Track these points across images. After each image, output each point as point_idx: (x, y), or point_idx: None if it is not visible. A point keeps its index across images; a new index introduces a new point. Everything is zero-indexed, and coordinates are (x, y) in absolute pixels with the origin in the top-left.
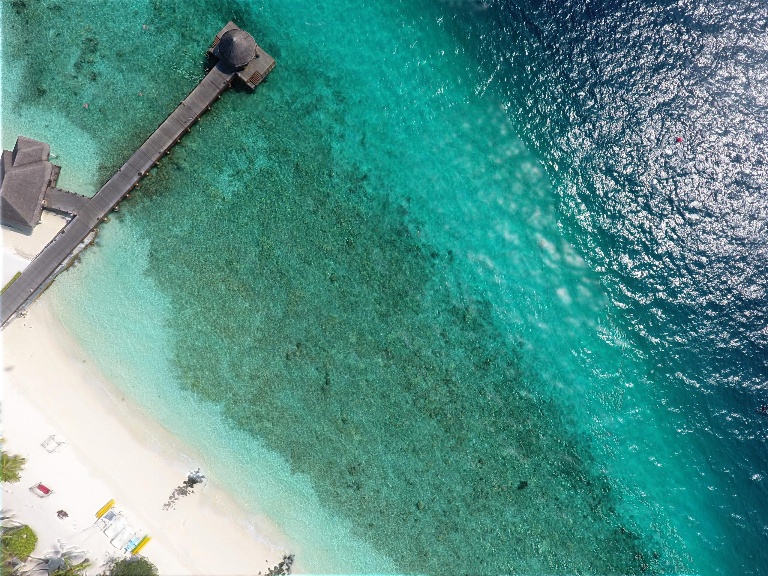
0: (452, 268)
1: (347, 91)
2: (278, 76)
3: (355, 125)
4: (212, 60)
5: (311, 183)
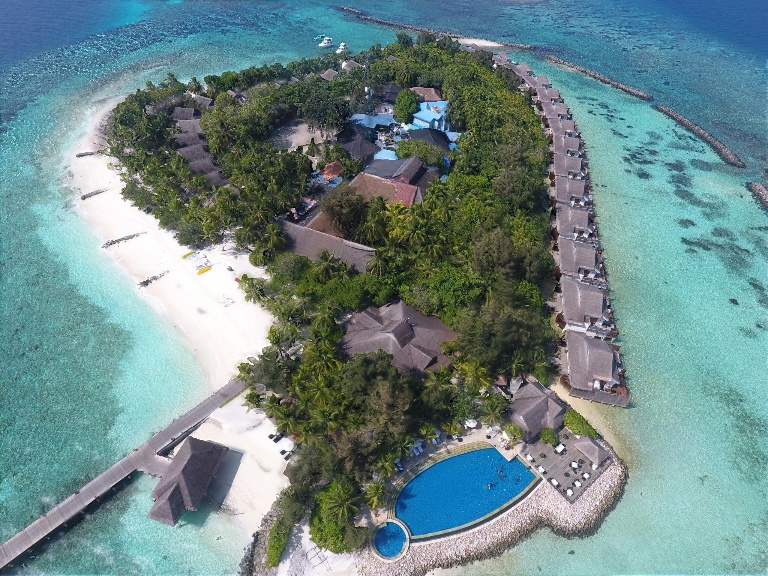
0: None
1: None
2: None
3: None
4: None
5: None
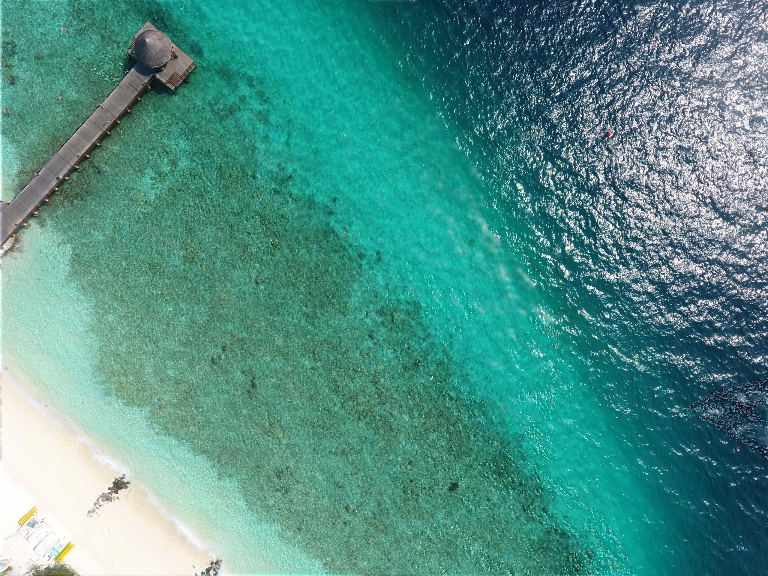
0: (380, 268)
1: (271, 91)
2: (200, 77)
3: (279, 125)
4: (131, 62)
5: (235, 185)
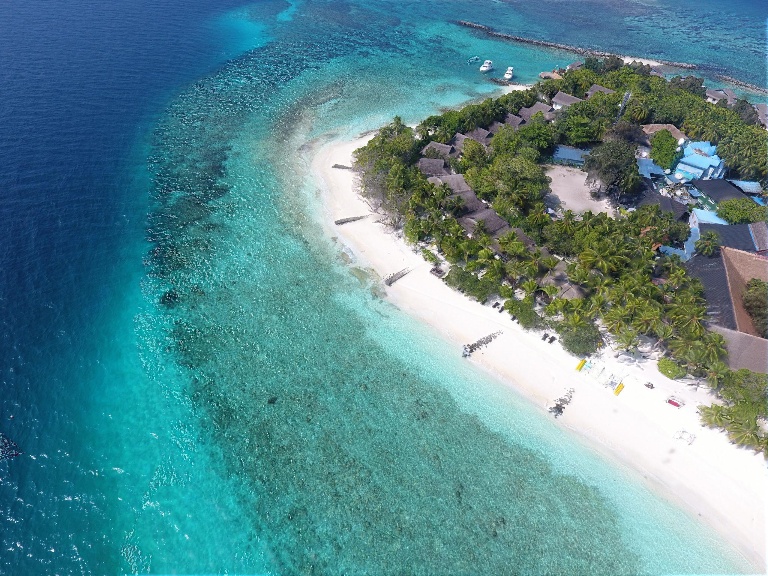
0: None
1: None
2: None
3: None
4: None
5: None
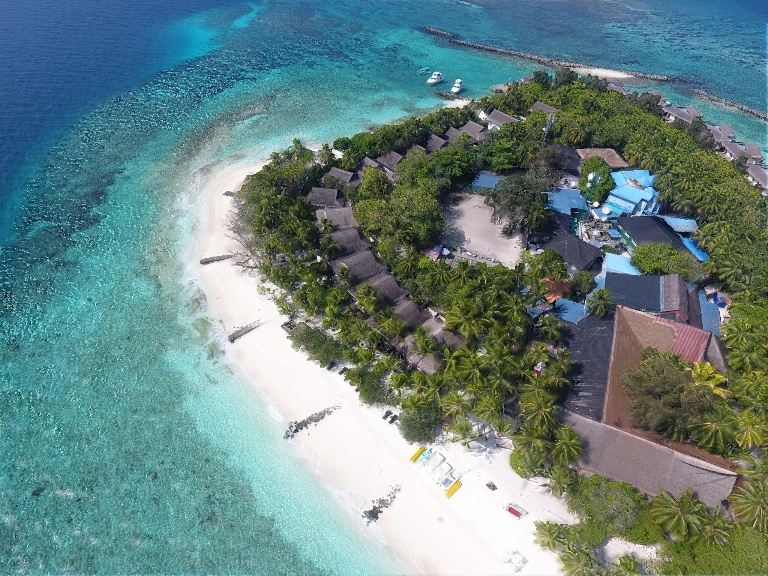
0: None
1: None
2: None
3: None
4: None
5: None
